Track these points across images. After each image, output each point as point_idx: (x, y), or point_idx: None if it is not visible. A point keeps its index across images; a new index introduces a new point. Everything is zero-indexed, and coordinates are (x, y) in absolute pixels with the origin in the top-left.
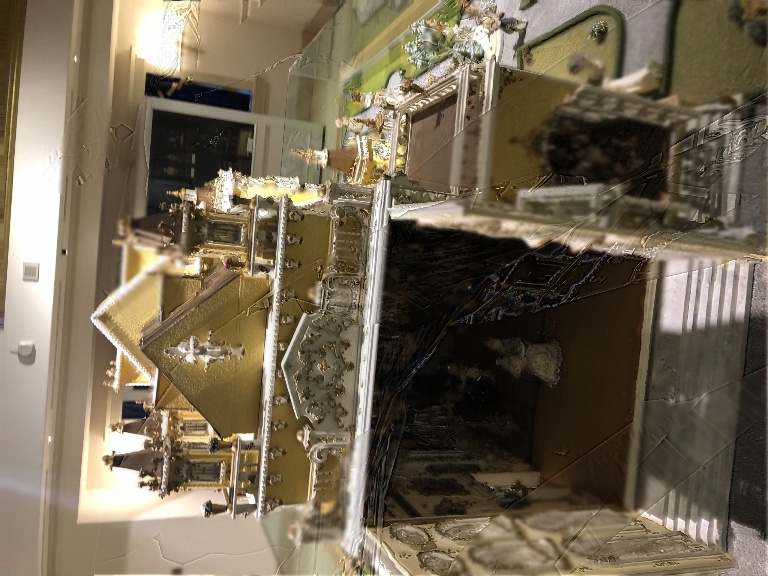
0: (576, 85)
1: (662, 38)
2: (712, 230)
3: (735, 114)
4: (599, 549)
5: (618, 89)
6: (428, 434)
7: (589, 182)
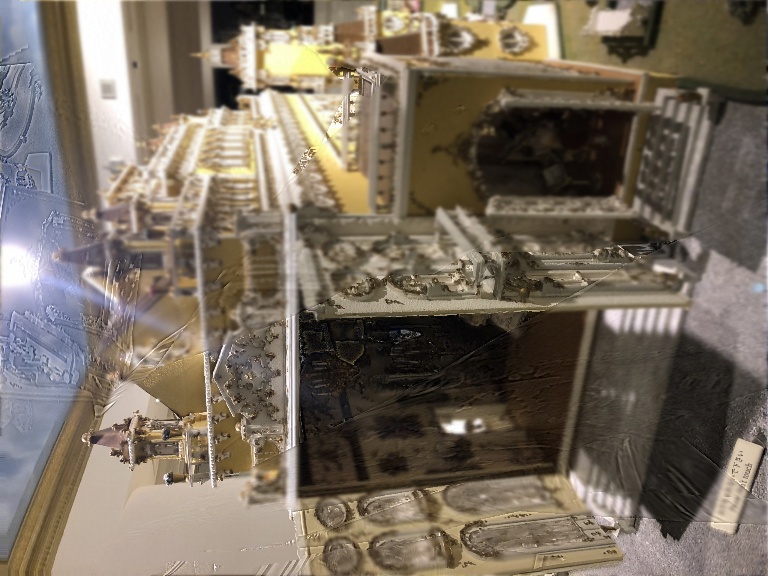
0: (184, 510)
1: (257, 479)
2: (421, 506)
3: (308, 570)
4: (492, 539)
5: (235, 499)
6: (404, 364)
7: (219, 567)
